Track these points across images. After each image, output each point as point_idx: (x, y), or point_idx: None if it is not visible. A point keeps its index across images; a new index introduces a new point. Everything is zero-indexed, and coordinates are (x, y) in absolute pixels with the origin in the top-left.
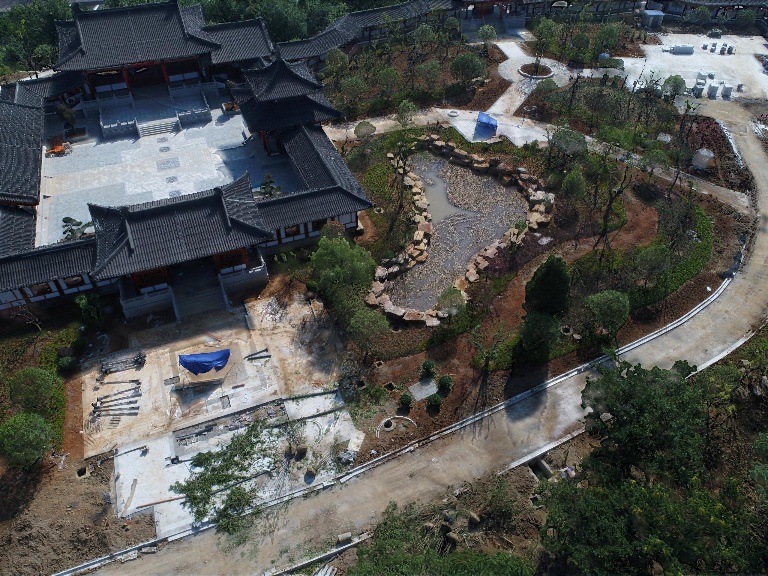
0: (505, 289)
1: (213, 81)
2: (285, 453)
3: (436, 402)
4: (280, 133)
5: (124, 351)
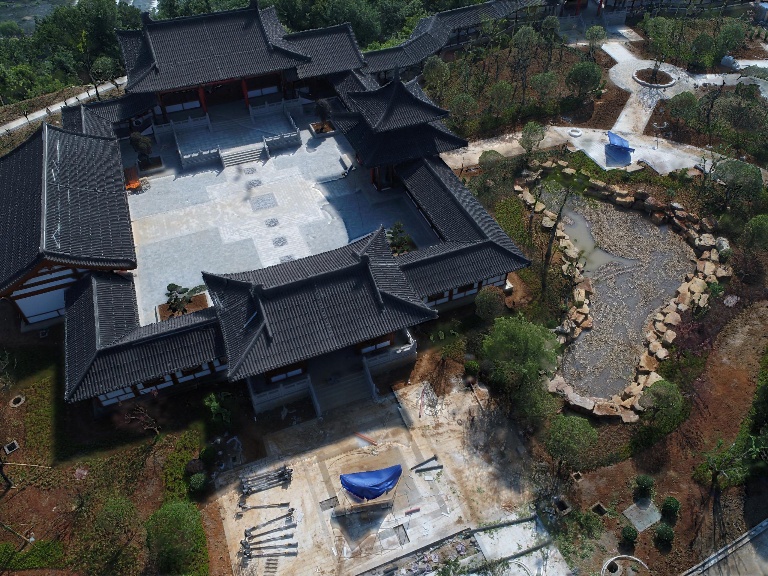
0: (704, 369)
1: (298, 98)
2: None
3: (669, 537)
4: (395, 166)
5: (262, 461)
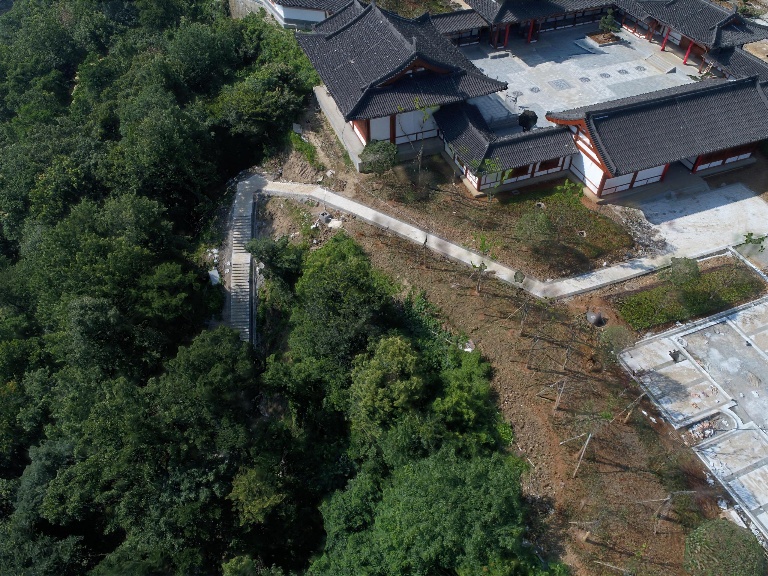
0: None
1: None
2: None
3: None
4: None
5: None
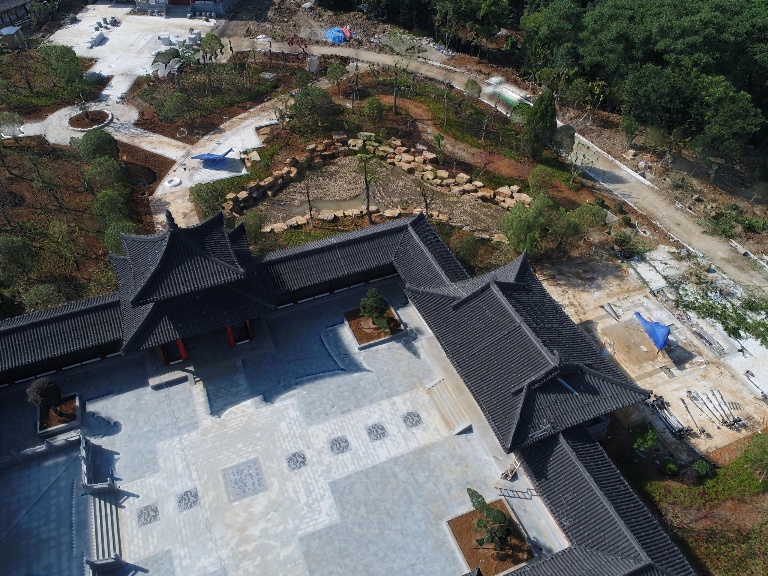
0: None
1: None
2: (699, 284)
3: None
4: None
5: None
